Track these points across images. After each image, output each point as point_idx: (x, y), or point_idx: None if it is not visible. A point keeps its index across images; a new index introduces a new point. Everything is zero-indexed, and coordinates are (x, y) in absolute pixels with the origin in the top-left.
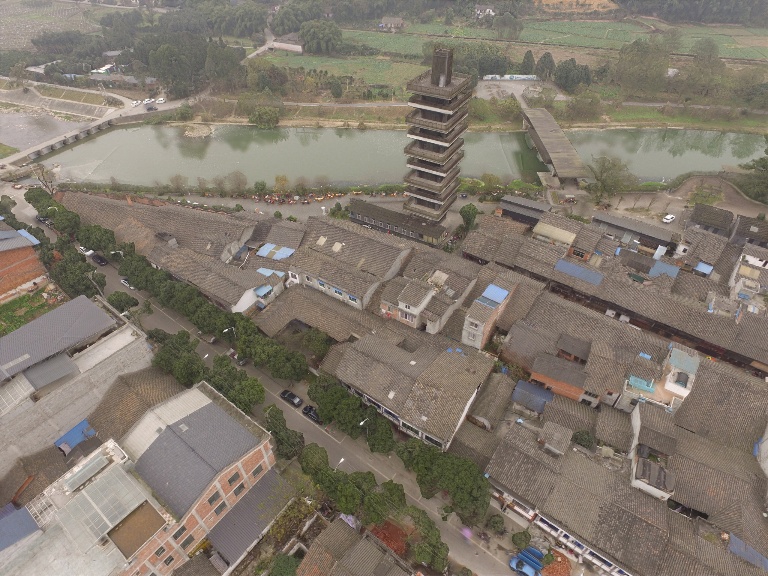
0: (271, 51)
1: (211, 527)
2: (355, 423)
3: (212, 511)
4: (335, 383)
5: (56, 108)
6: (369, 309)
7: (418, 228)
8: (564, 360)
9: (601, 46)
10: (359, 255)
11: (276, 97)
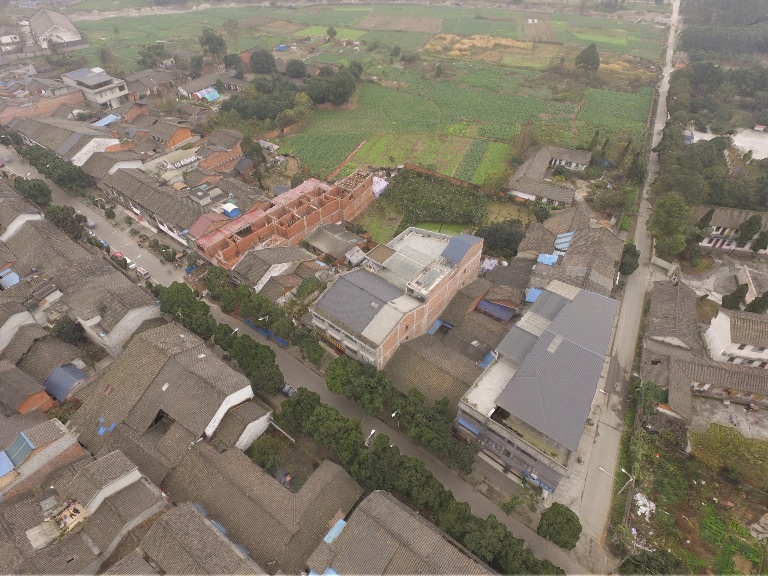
0: None
1: None
2: None
3: None
4: None
5: None
6: None
7: None
8: (1, 397)
9: None
10: None
11: None
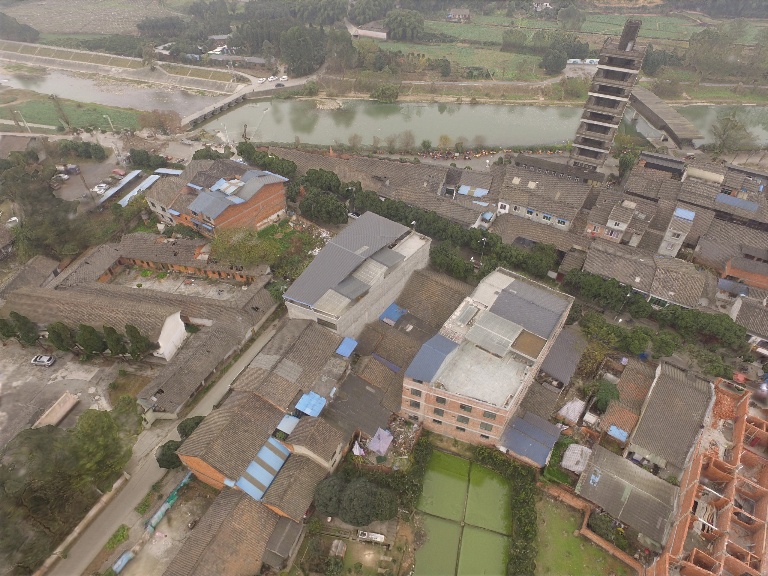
0: (356, 38)
1: (541, 362)
2: (620, 297)
3: (548, 347)
4: (587, 274)
5: (186, 84)
6: (573, 231)
7: (583, 174)
8: (753, 260)
9: (658, 36)
10: (554, 190)
11: (395, 75)
